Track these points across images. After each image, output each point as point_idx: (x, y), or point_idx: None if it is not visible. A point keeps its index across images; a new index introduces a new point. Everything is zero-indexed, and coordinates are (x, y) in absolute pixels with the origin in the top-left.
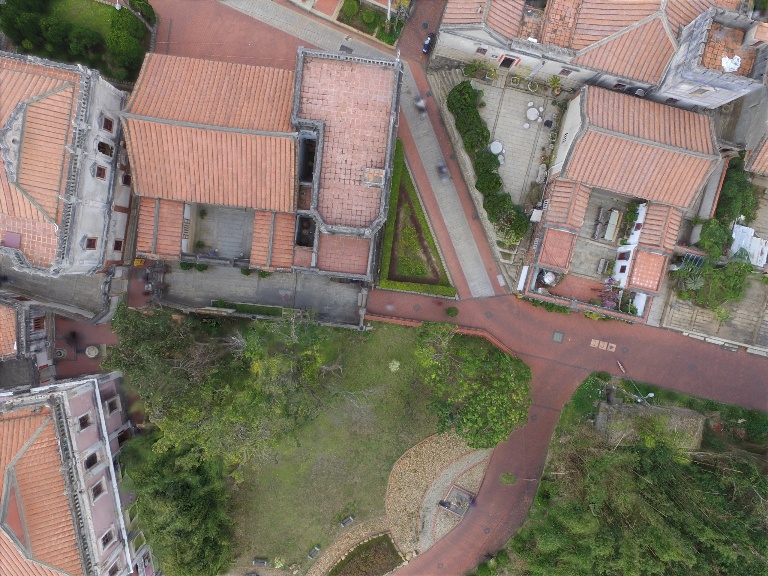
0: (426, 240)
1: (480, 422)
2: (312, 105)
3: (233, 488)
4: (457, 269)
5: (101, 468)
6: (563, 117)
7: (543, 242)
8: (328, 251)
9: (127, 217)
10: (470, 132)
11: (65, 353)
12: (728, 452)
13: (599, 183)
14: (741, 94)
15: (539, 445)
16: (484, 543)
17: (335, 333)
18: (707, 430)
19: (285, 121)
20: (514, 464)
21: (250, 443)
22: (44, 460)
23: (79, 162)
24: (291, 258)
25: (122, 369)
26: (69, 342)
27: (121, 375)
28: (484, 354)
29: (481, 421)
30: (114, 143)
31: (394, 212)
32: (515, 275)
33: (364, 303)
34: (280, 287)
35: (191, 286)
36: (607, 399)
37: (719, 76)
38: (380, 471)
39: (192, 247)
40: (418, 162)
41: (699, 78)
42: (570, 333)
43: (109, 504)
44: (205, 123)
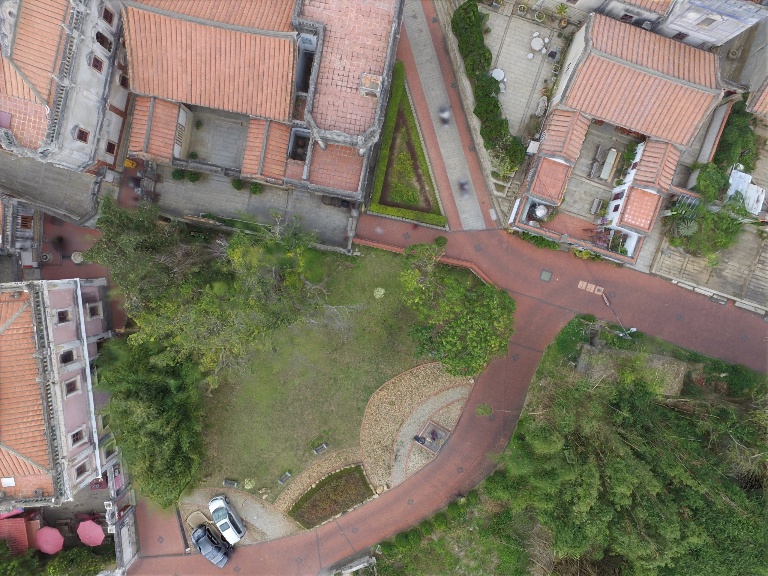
0: (421, 168)
1: (459, 345)
2: (314, 8)
3: (207, 394)
4: (450, 200)
5: (77, 367)
6: (568, 50)
7: (537, 171)
8: (320, 166)
9: (122, 121)
10: (472, 53)
11: (51, 257)
12: (707, 400)
13: (598, 113)
14: (748, 25)
15: (519, 387)
16: (456, 482)
17: (322, 257)
18: (688, 381)
19: (286, 24)
20: (492, 404)
21: (225, 337)
22: (19, 346)
23: (75, 45)
24: (283, 170)
25: (103, 260)
26: (56, 247)
27: (105, 284)
28: (470, 289)
29: (460, 344)
30: (113, 38)
31: (390, 135)
32: (507, 209)
33: (354, 228)
34: (271, 206)
35: (181, 198)
36: (590, 342)
37: (727, 0)
38: (357, 401)
39: (185, 157)
40: (419, 88)
41: (707, 3)
42: (558, 273)
43: (82, 404)
44: (205, 19)
